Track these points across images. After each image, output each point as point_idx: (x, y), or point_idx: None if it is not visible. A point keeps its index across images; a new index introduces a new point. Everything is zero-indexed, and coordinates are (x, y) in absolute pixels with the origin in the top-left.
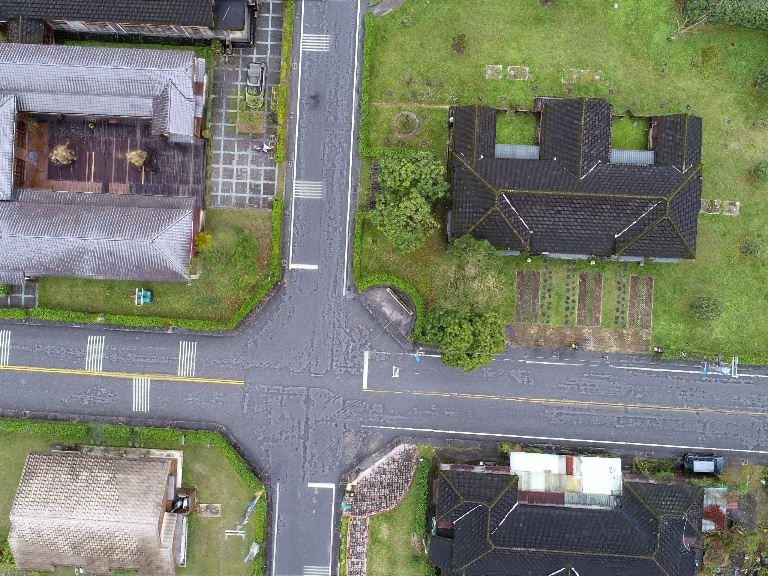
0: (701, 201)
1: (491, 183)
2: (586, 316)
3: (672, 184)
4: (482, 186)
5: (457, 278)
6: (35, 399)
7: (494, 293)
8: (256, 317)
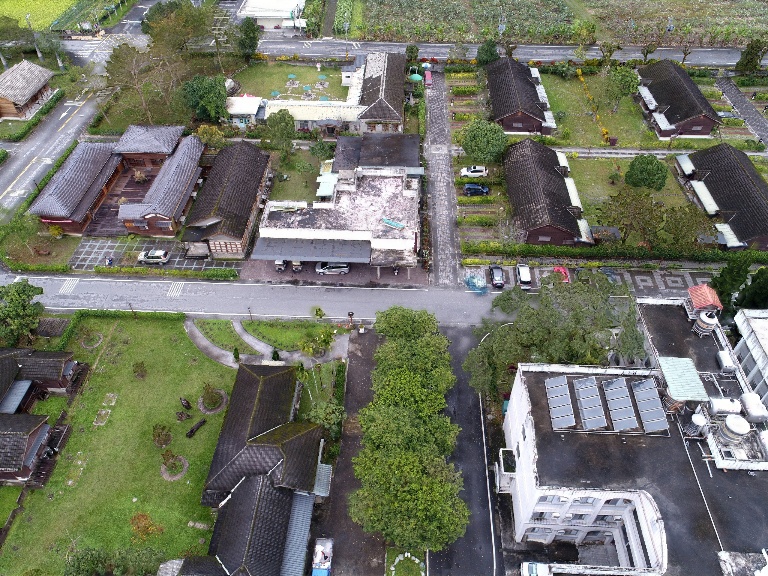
0: None
1: None
2: None
3: None
4: None
5: None
6: (6, 172)
7: None
8: None
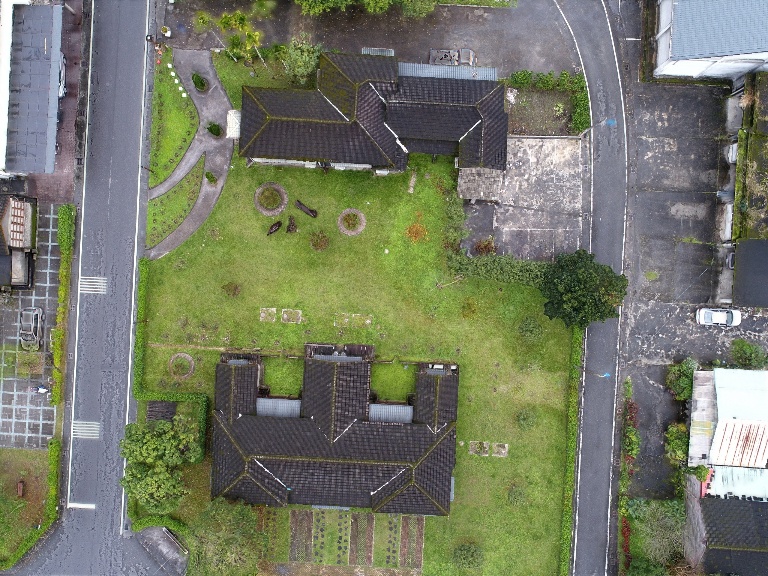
0: (470, 443)
1: (243, 447)
2: (358, 555)
3: (422, 447)
4: (235, 450)
5: (200, 552)
6: None
7: (236, 567)
8: (35, 555)
